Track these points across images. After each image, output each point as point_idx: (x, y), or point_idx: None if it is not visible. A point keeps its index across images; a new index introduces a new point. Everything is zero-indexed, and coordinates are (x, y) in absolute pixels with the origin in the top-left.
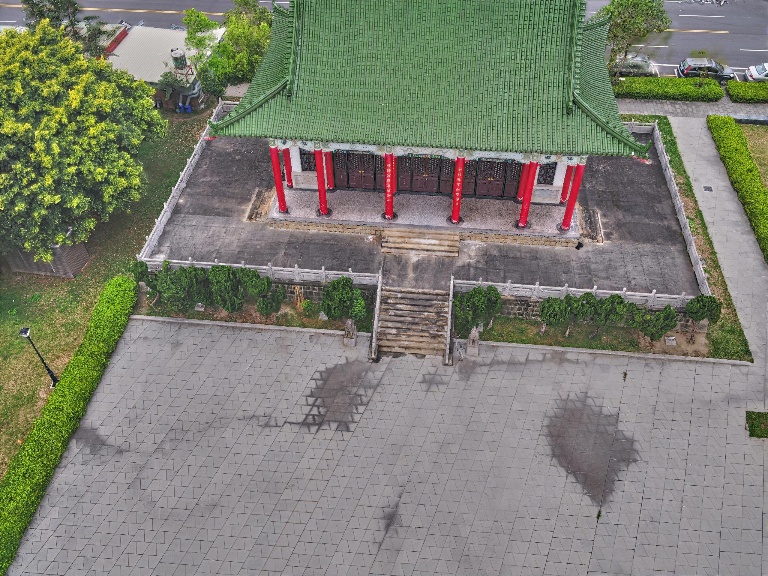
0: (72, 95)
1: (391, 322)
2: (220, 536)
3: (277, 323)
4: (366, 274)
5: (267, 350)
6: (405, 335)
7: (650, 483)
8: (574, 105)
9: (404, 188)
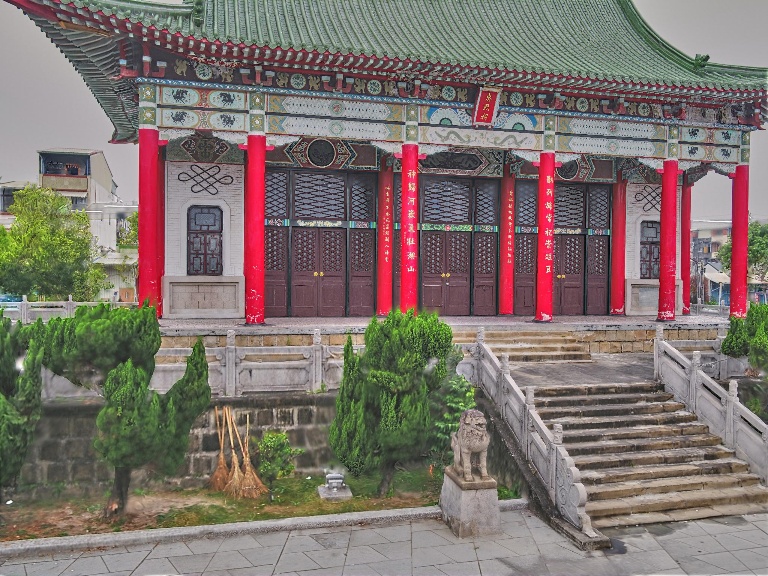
0: None
1: None
2: None
3: (166, 525)
4: None
5: None
6: (632, 479)
7: None
8: None
9: None
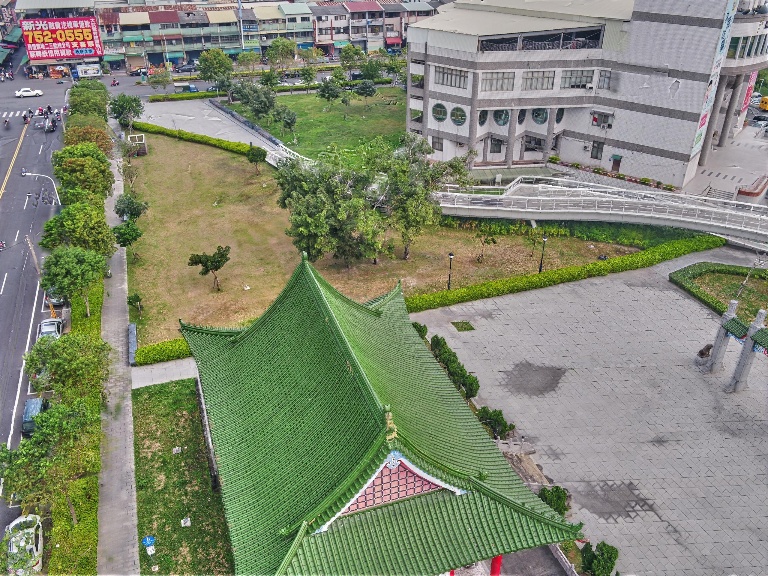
0: None
1: None
2: (759, 515)
3: None
4: None
5: (623, 567)
6: None
7: (536, 356)
8: None
9: None
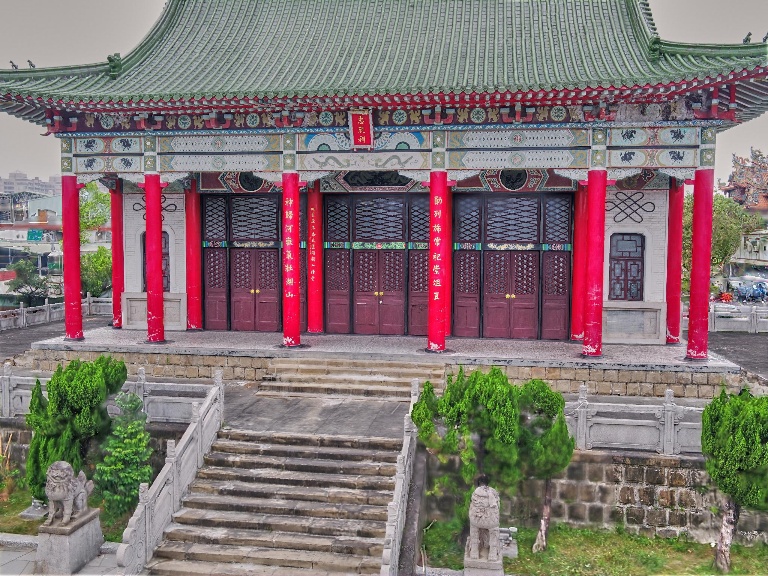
0: None
1: (219, 510)
2: None
3: None
4: (181, 384)
5: None
6: (252, 545)
7: None
8: (661, 56)
9: (337, 328)
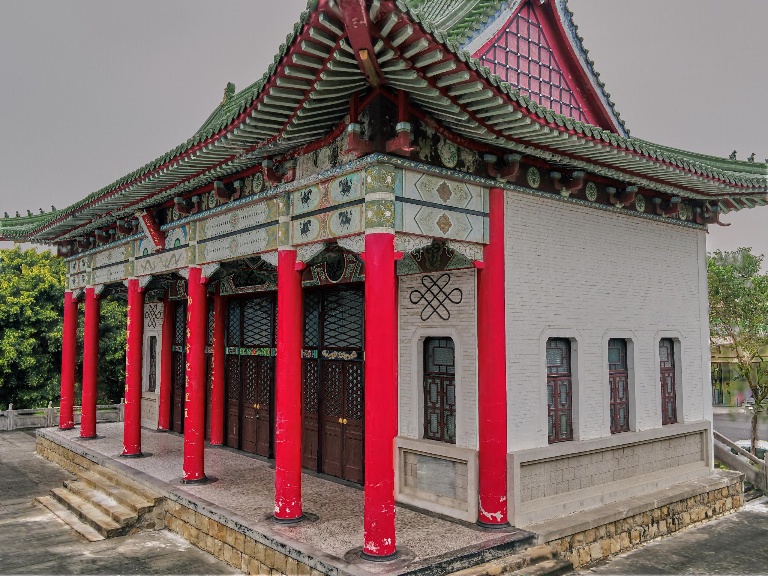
0: (35, 269)
1: None
2: None
3: None
4: None
5: None
6: None
7: None
8: None
9: (234, 441)
